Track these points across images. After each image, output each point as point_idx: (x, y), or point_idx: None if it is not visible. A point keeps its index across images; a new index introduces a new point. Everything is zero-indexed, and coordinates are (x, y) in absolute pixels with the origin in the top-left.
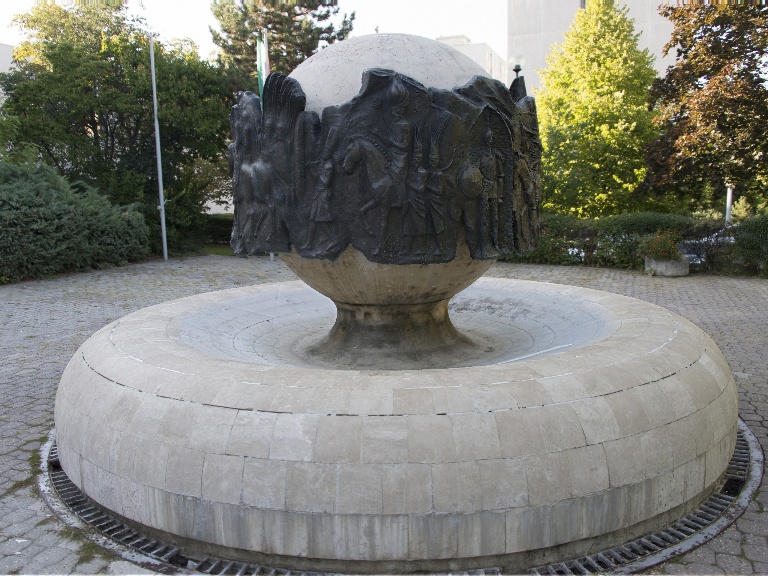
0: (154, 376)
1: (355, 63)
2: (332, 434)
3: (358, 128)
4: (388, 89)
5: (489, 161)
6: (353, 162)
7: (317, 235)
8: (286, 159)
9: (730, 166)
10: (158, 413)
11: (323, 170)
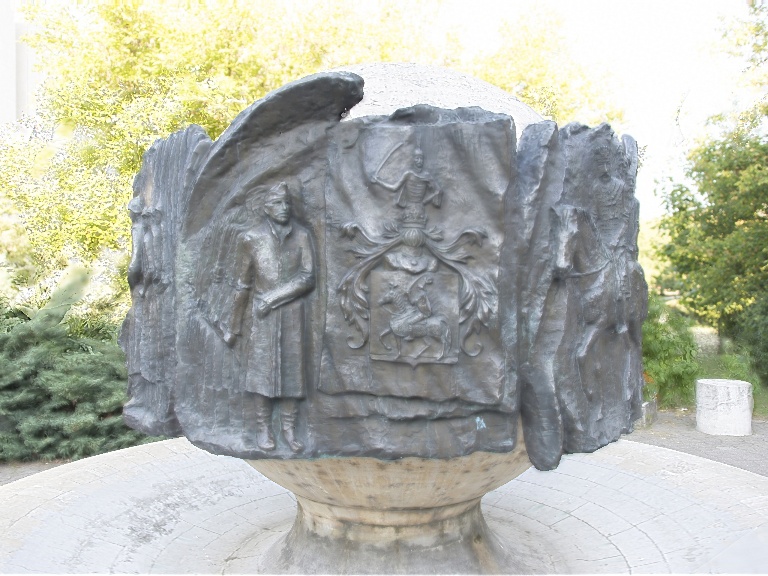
0: None
1: None
2: None
3: None
4: None
5: None
6: None
7: None
8: None
9: None
10: None
11: None
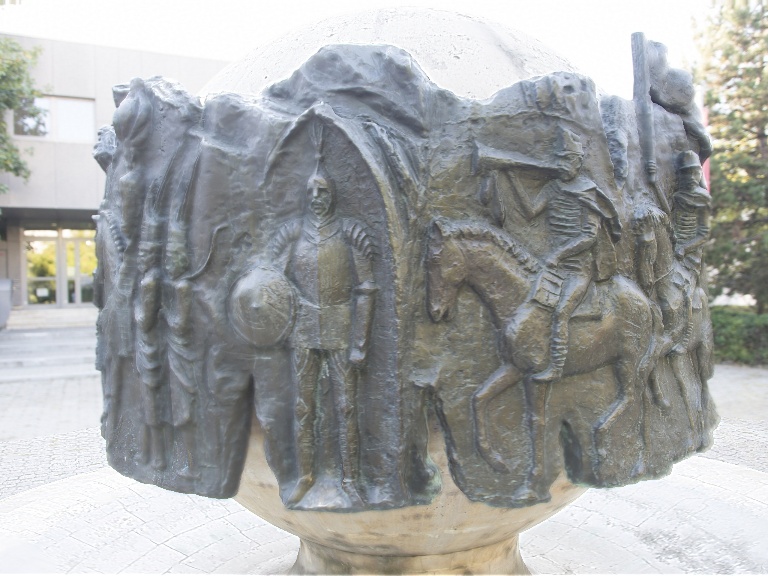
0: None
1: None
2: None
3: None
4: None
5: (310, 251)
6: (100, 263)
7: None
8: None
9: None
10: None
11: None
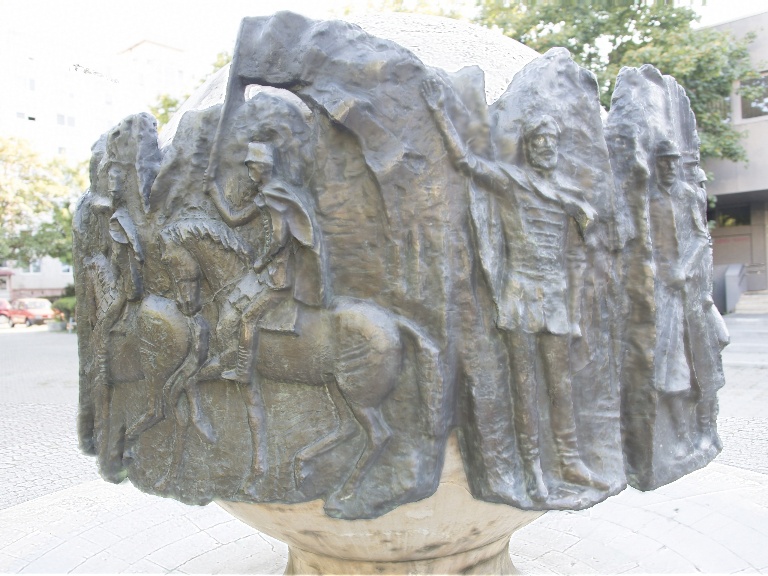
0: None
1: None
2: None
3: None
4: None
5: None
6: None
7: None
8: None
9: None
10: None
11: None
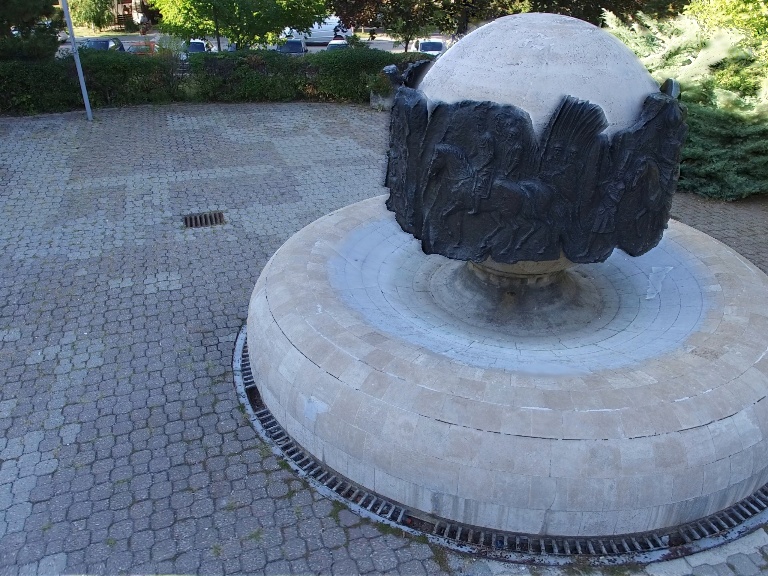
0: (600, 422)
1: (609, 75)
2: (765, 416)
3: (646, 150)
4: (672, 115)
5: None
6: None
7: (596, 244)
8: (576, 180)
9: (429, 7)
10: (647, 453)
11: (616, 190)
